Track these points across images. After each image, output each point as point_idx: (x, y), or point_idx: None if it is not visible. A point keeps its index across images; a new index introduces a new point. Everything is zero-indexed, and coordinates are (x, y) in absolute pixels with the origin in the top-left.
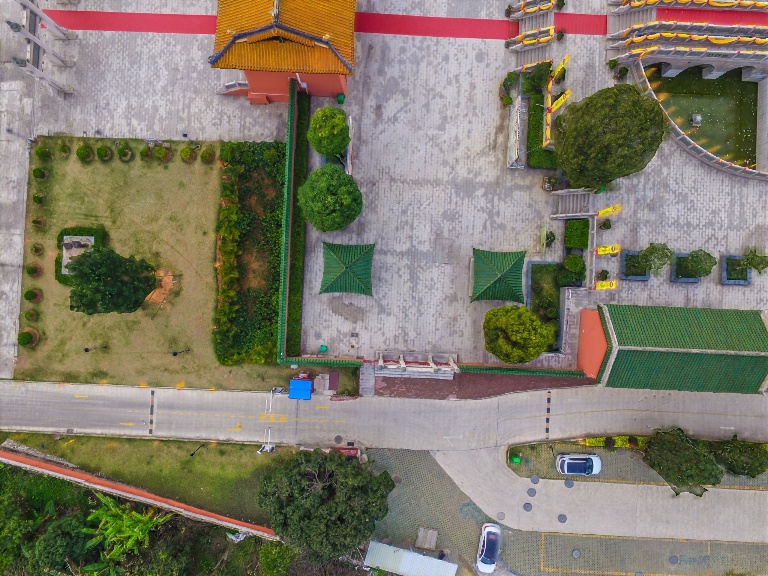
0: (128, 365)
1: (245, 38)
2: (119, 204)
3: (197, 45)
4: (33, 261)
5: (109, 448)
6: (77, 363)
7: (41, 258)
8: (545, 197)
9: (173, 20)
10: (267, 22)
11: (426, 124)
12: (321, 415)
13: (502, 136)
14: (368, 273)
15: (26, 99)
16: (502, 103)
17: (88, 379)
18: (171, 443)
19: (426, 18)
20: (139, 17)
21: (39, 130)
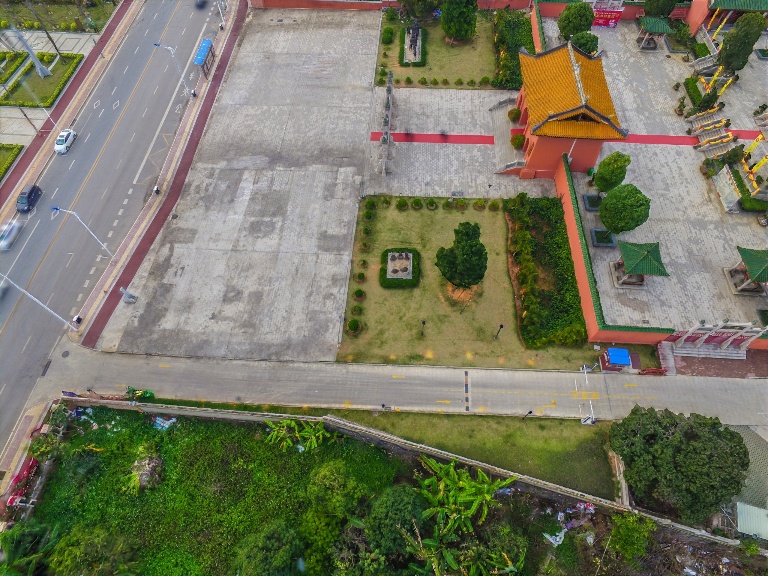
0: (442, 349)
1: (556, 118)
2: (428, 235)
3: (477, 149)
4: (359, 272)
5: (429, 423)
6: (395, 348)
7: (365, 270)
8: (763, 230)
9: (459, 137)
10: (575, 107)
11: (654, 187)
12: (631, 392)
13: (713, 195)
14: (660, 261)
15: (357, 176)
16: (705, 177)
17: (406, 361)
18: (490, 418)
19: (634, 135)
20: (436, 136)
21: (367, 192)
